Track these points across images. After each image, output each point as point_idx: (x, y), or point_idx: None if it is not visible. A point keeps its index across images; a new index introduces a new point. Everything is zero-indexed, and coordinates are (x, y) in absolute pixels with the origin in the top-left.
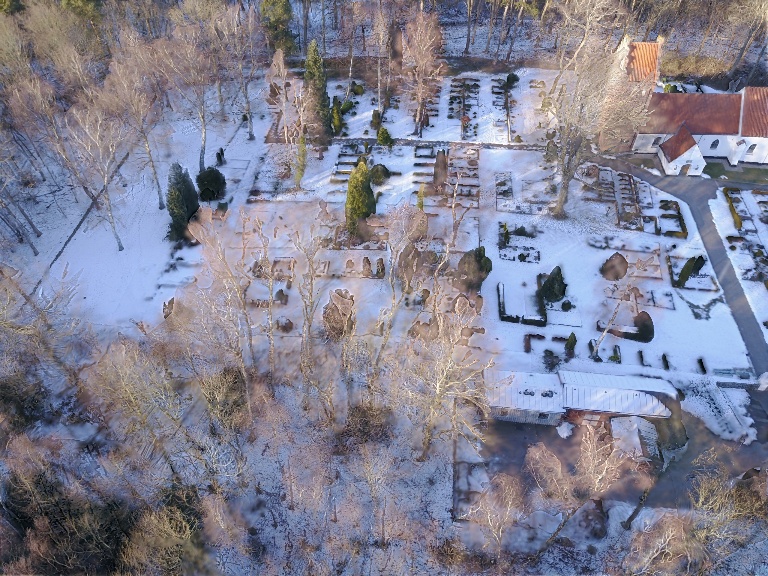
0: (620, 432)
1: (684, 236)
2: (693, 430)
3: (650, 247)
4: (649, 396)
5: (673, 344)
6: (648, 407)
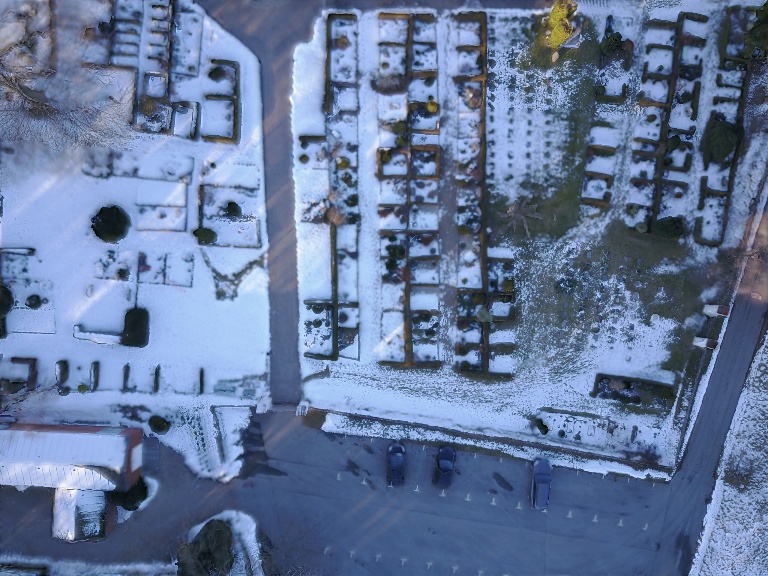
0: (59, 507)
1: (233, 142)
2: (168, 471)
3: (176, 171)
4: (88, 471)
5: (176, 347)
6: (88, 482)
